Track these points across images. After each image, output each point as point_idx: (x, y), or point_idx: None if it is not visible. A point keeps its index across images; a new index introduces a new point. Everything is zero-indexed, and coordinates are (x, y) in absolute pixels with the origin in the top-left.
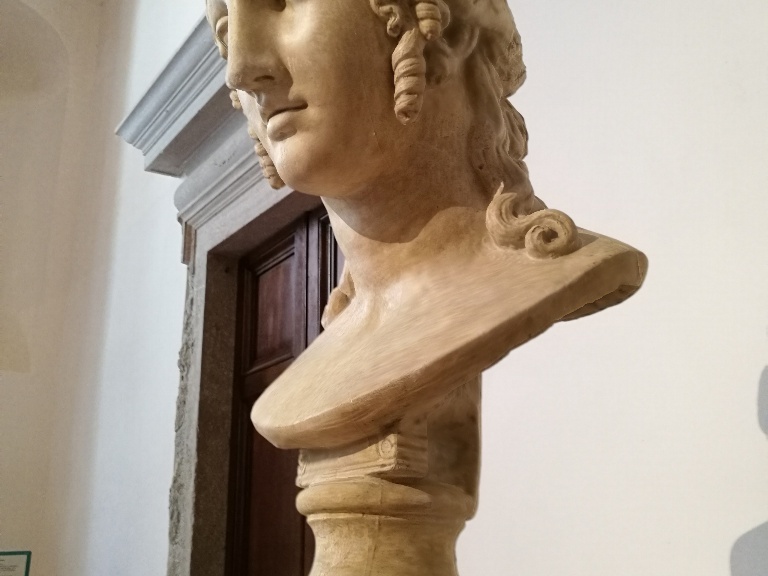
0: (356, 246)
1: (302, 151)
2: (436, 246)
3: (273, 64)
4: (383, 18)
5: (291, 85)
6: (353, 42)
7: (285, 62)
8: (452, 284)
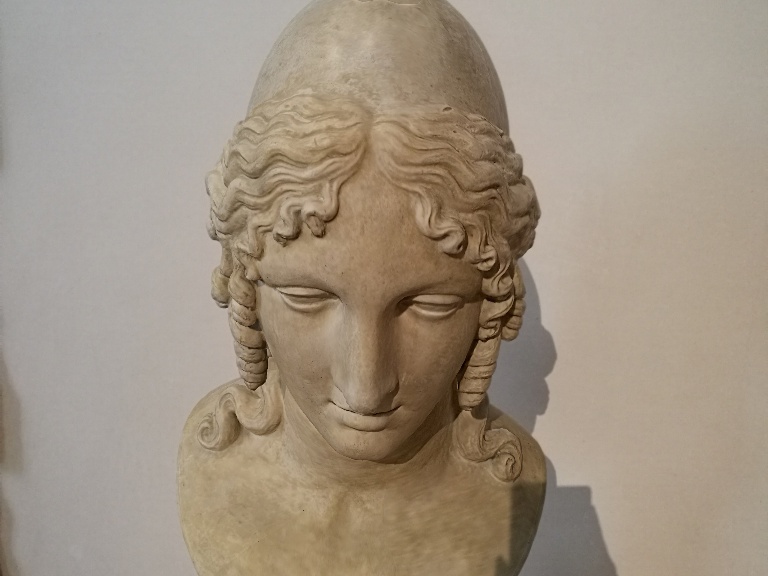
0: (347, 459)
1: (386, 447)
2: (422, 464)
3: (394, 384)
4: (483, 327)
5: (396, 394)
6: (462, 358)
7: (400, 376)
8: (433, 497)
